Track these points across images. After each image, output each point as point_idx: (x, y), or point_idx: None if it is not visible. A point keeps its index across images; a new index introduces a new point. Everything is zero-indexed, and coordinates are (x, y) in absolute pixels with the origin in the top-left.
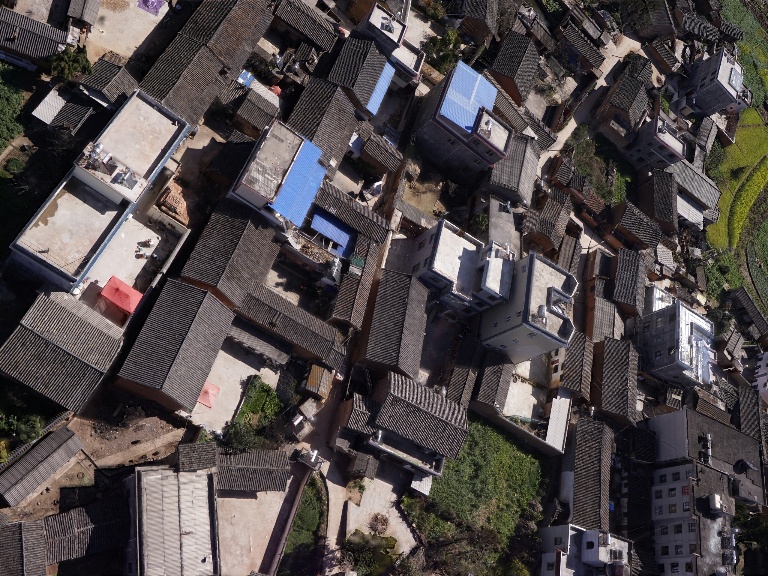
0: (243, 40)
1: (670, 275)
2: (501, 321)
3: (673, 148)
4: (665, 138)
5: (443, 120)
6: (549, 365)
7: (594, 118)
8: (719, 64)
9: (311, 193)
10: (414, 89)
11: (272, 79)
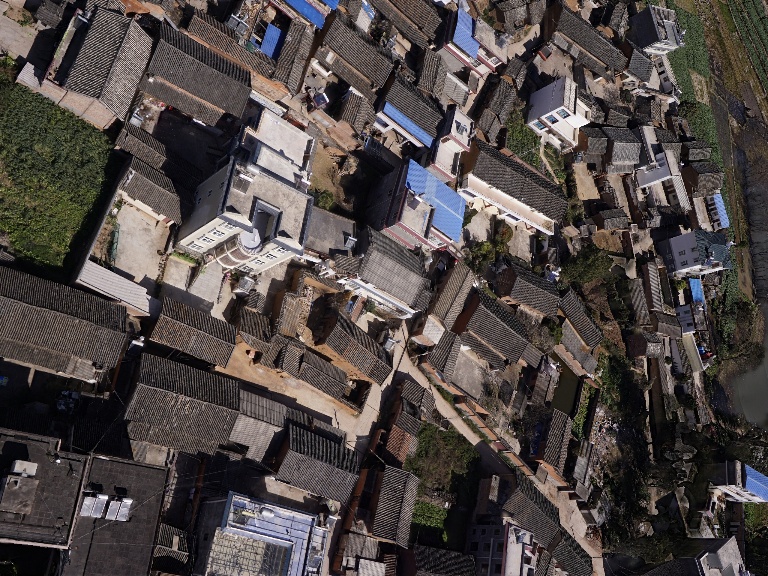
0: (395, 3)
1: None
2: None
3: (507, 559)
4: (513, 546)
5: (406, 169)
6: None
7: None
8: None
9: (298, 6)
10: None
11: None
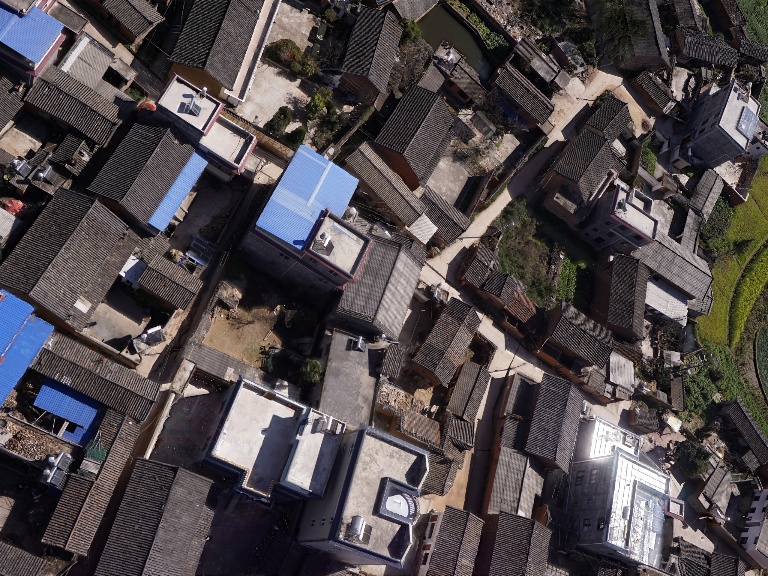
0: None
1: (626, 398)
2: (317, 521)
3: (638, 229)
4: (628, 215)
5: (264, 232)
6: (420, 550)
7: (538, 187)
8: (724, 103)
9: (20, 365)
10: (250, 180)
11: (15, 189)
